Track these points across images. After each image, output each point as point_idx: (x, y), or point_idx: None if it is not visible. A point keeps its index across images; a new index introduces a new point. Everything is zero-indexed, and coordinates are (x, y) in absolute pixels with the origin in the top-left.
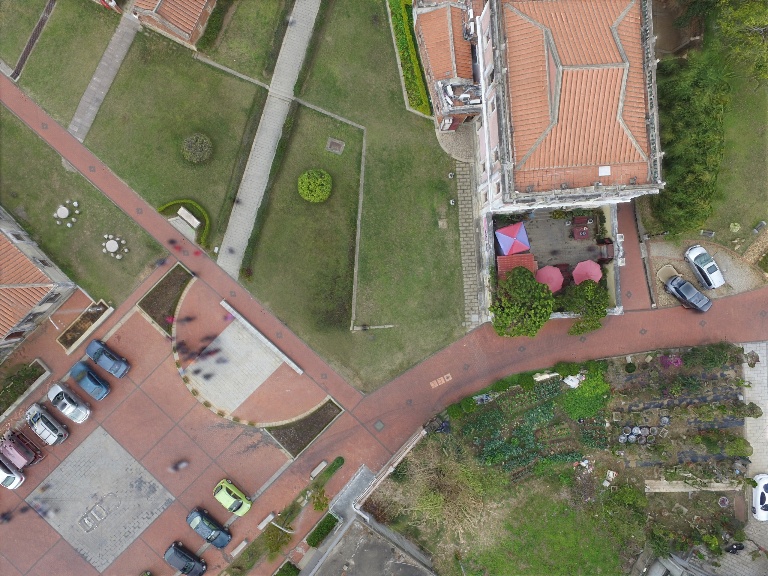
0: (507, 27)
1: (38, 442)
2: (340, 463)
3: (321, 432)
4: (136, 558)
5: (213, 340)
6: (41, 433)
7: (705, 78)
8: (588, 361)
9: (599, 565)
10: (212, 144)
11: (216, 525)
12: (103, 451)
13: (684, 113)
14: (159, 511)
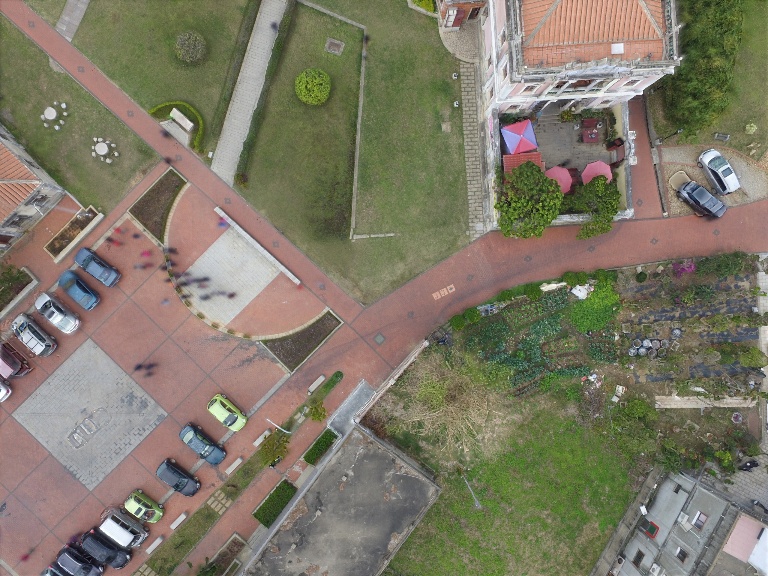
0: None
1: (25, 353)
2: None
3: (319, 345)
4: (127, 476)
5: (207, 249)
6: (28, 342)
7: None
8: (597, 270)
9: (607, 484)
10: (206, 43)
11: (210, 441)
12: (93, 364)
13: None
14: (151, 427)
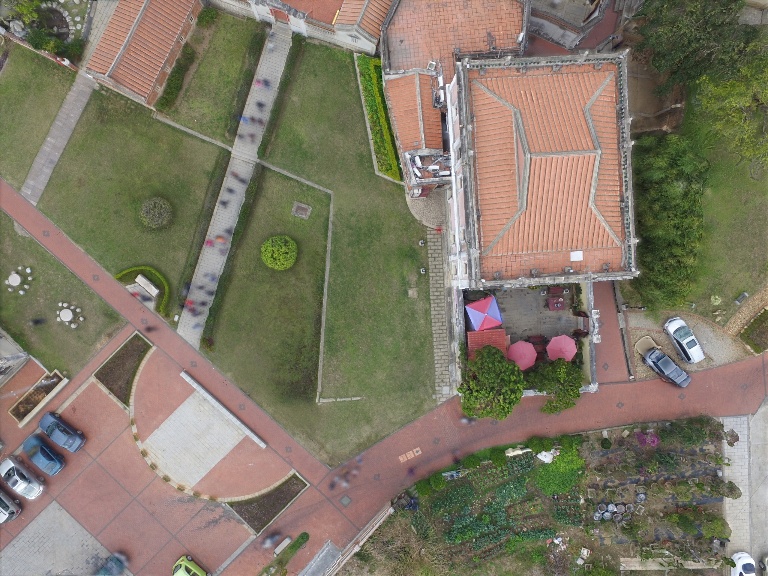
0: (475, 105)
1: None
2: (305, 539)
3: (285, 507)
4: None
5: (173, 412)
6: None
7: (684, 155)
8: (562, 437)
9: None
10: (172, 208)
11: None
12: (58, 526)
13: (661, 192)
14: None
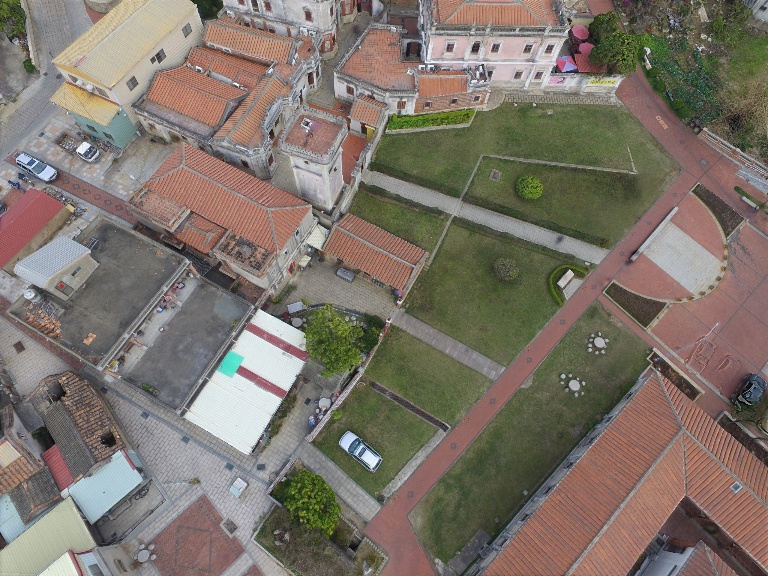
0: None
1: None
2: (740, 188)
3: None
4: None
5: (664, 271)
6: None
7: None
8: None
9: (765, 47)
10: None
11: None
12: None
13: None
14: None
